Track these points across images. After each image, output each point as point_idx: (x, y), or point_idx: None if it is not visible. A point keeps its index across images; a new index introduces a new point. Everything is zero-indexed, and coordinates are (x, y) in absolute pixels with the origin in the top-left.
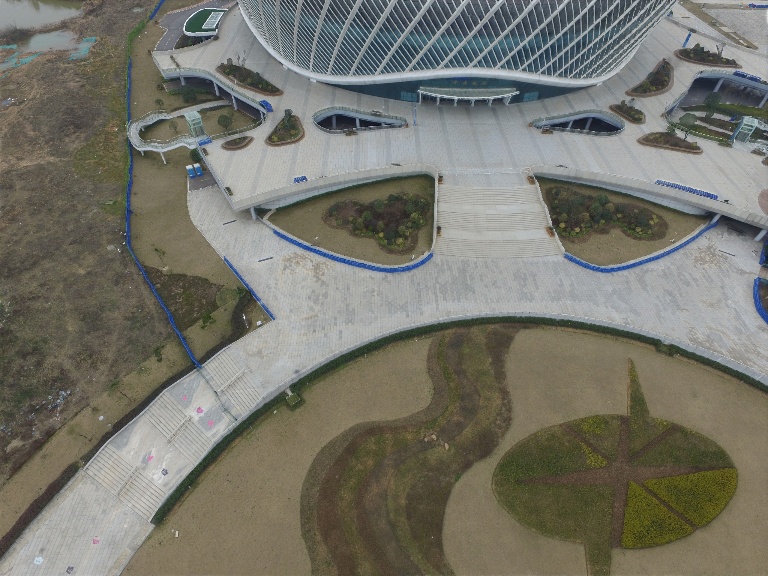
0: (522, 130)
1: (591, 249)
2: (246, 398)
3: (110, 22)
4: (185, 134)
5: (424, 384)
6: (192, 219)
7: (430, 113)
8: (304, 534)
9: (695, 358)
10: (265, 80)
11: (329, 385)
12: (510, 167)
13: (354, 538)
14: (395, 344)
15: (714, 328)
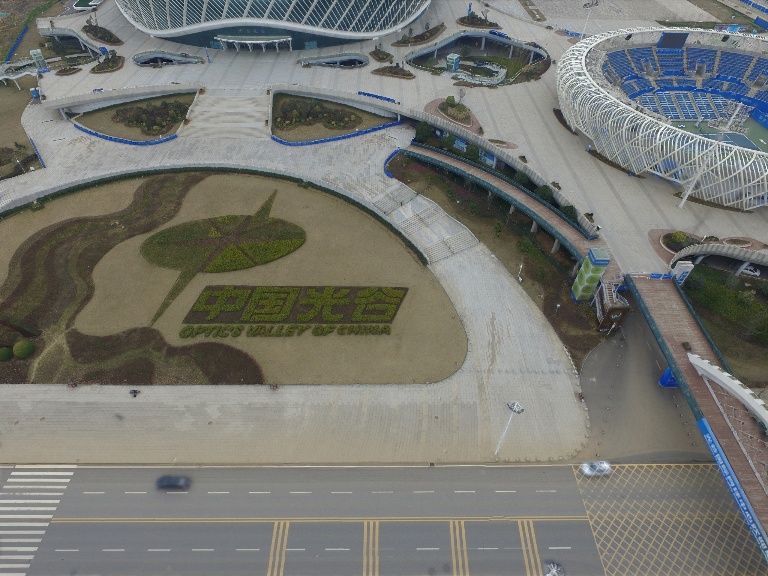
0: (289, 65)
1: (292, 134)
2: None
3: (24, 3)
4: (31, 66)
5: (128, 200)
6: (21, 120)
7: (227, 56)
8: (10, 264)
9: (320, 189)
10: (113, 35)
11: (65, 200)
12: (260, 86)
13: (40, 266)
14: (121, 181)
15: (345, 174)
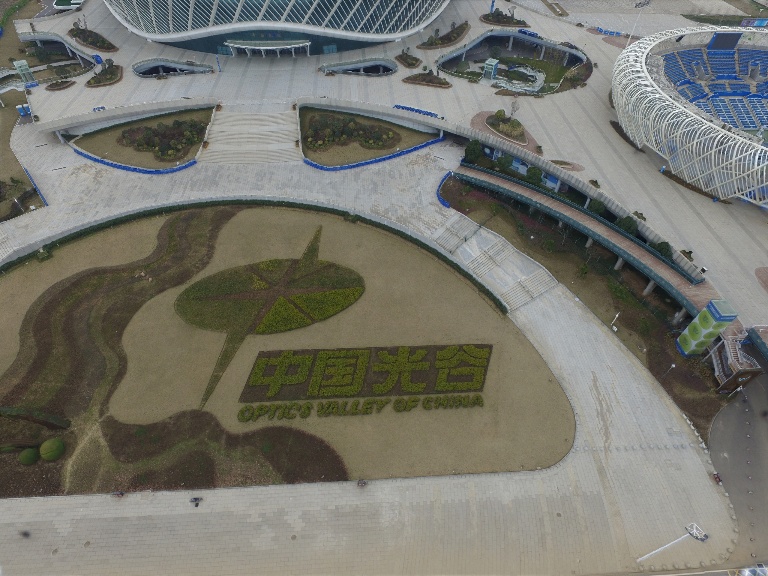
0: (310, 74)
1: (327, 156)
2: (4, 254)
3: None
4: None
5: (151, 244)
6: (10, 144)
7: (239, 63)
8: (21, 332)
9: (370, 223)
10: (105, 40)
11: (76, 246)
12: None
13: (57, 333)
14: (140, 220)
15: (395, 204)
